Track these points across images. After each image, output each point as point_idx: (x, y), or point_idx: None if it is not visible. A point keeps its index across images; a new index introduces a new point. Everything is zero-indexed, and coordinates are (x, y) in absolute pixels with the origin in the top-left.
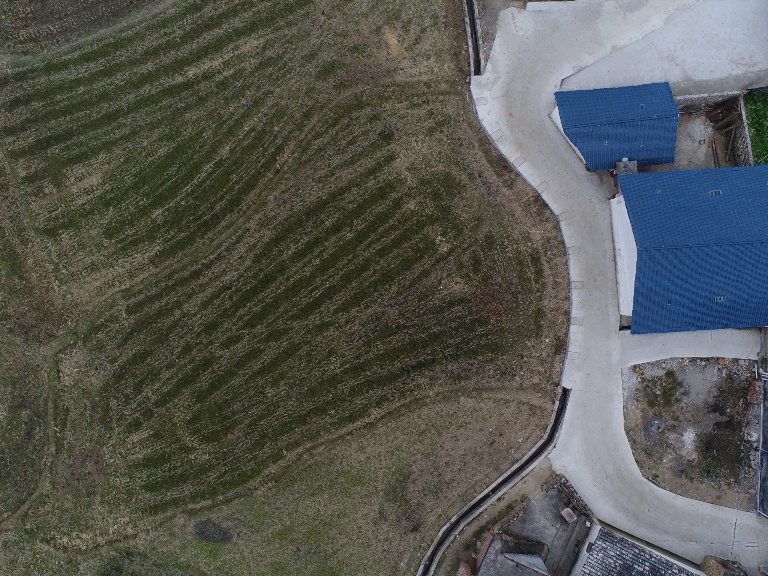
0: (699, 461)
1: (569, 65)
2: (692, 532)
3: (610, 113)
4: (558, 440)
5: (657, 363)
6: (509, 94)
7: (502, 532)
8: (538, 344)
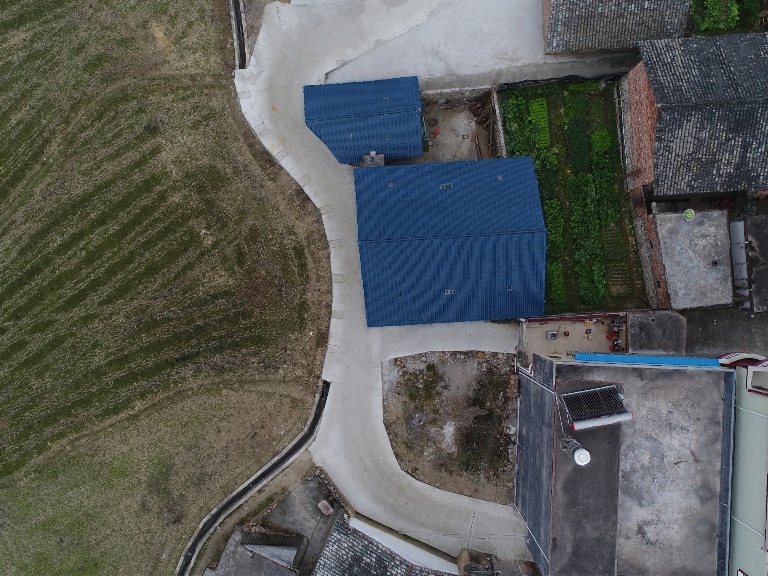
0: (459, 454)
1: (333, 59)
2: (449, 525)
3: (353, 107)
4: (318, 433)
5: (418, 356)
6: (272, 88)
7: (257, 524)
8: (302, 337)
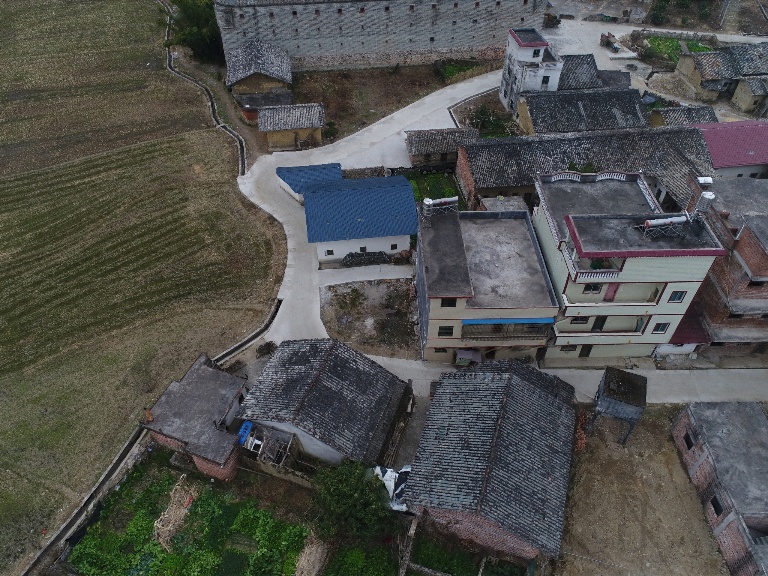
0: (378, 335)
1: None
2: None
3: None
4: (271, 327)
5: (346, 286)
6: (259, 181)
7: None
8: (265, 282)
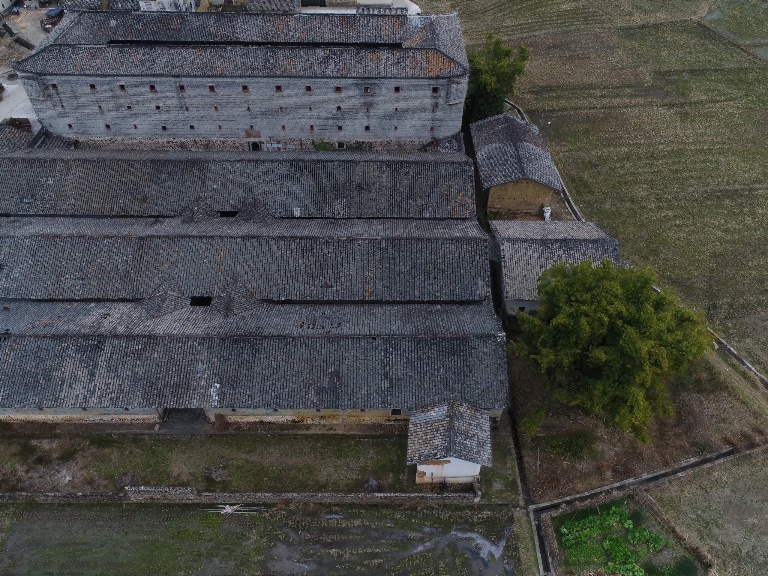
0: None
1: None
2: None
3: None
4: None
5: None
6: None
7: None
8: None
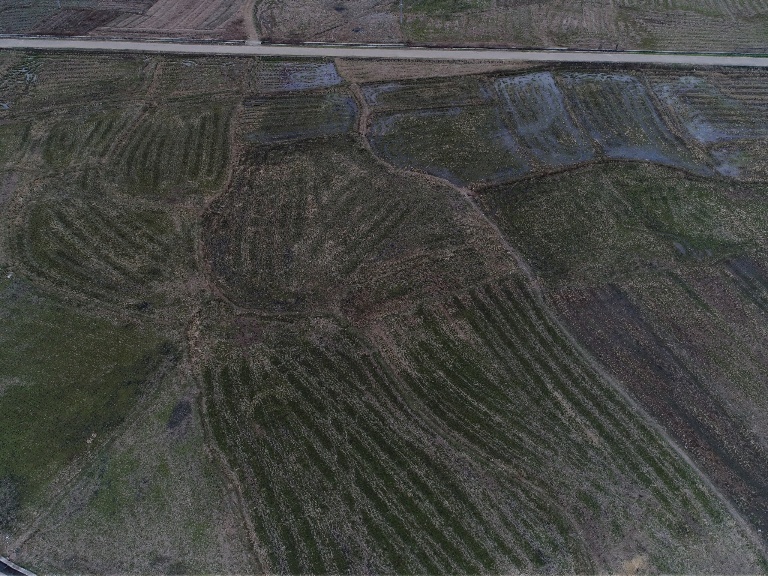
0: None
1: None
2: None
3: None
4: None
5: None
6: None
7: None
8: None
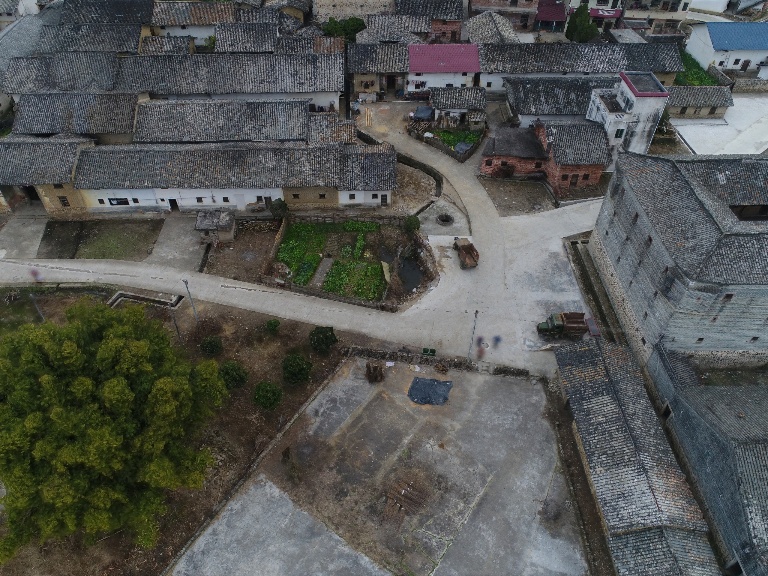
0: None
1: None
2: None
3: None
4: None
5: None
6: None
7: None
8: None
